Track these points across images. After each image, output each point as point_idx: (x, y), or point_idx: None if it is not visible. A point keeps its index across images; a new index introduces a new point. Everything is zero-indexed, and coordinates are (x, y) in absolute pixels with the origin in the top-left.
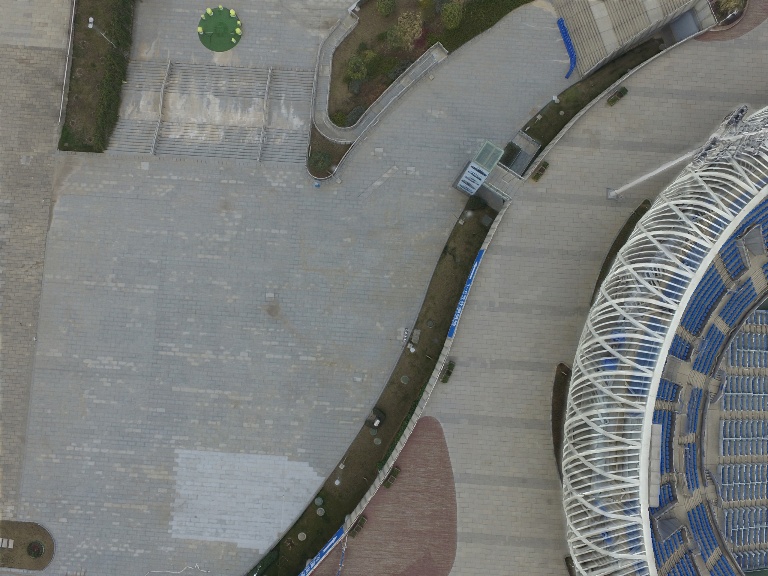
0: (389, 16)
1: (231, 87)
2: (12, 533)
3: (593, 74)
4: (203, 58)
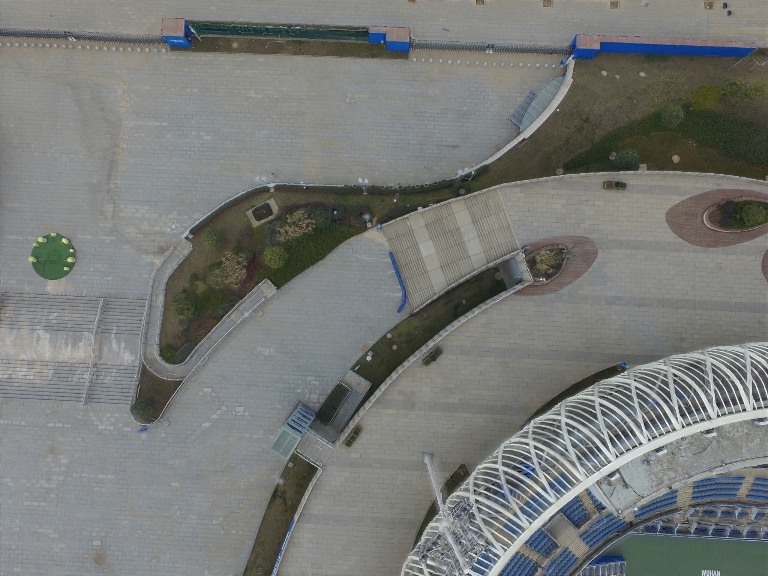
0: (222, 244)
1: (62, 320)
2: None
3: (426, 307)
4: (36, 287)
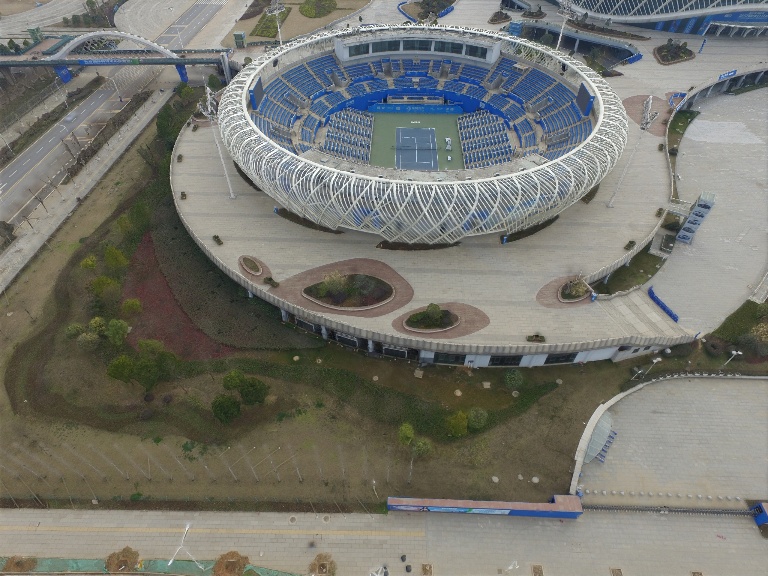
0: None
1: None
2: None
3: None
4: None
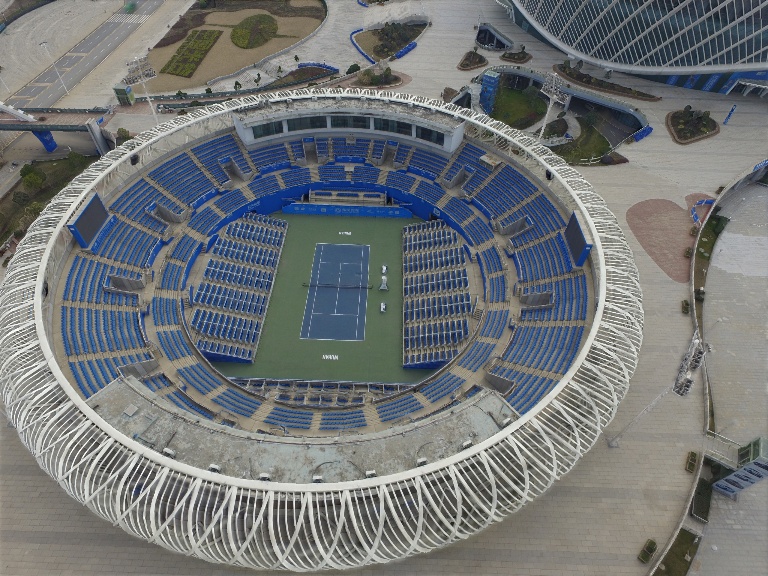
0: None
1: None
2: None
3: None
4: None
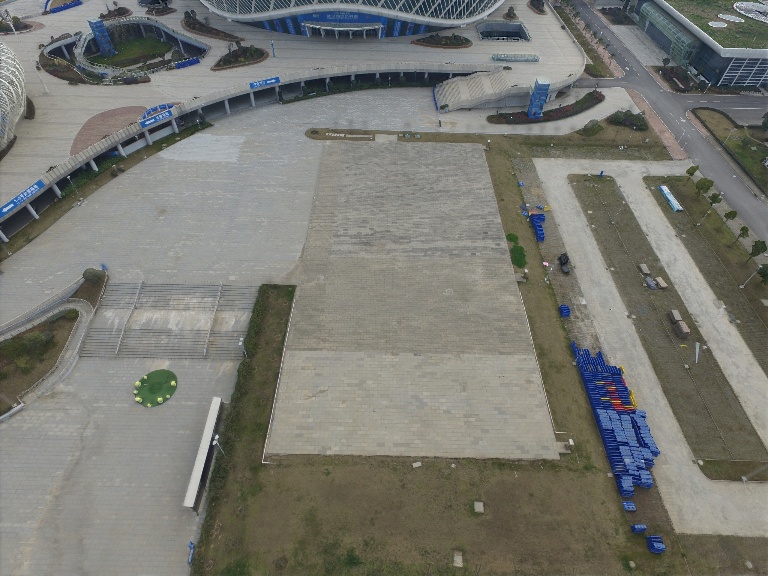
0: None
1: (157, 338)
2: (327, 137)
3: None
4: (178, 364)
